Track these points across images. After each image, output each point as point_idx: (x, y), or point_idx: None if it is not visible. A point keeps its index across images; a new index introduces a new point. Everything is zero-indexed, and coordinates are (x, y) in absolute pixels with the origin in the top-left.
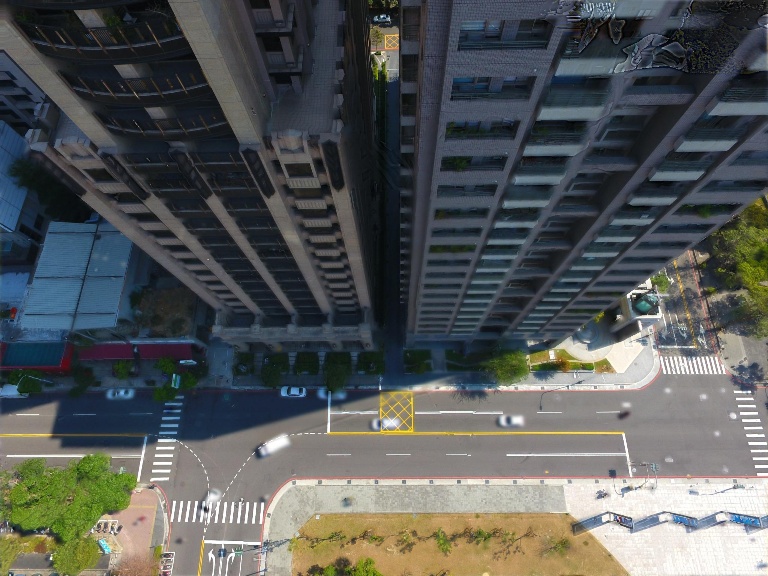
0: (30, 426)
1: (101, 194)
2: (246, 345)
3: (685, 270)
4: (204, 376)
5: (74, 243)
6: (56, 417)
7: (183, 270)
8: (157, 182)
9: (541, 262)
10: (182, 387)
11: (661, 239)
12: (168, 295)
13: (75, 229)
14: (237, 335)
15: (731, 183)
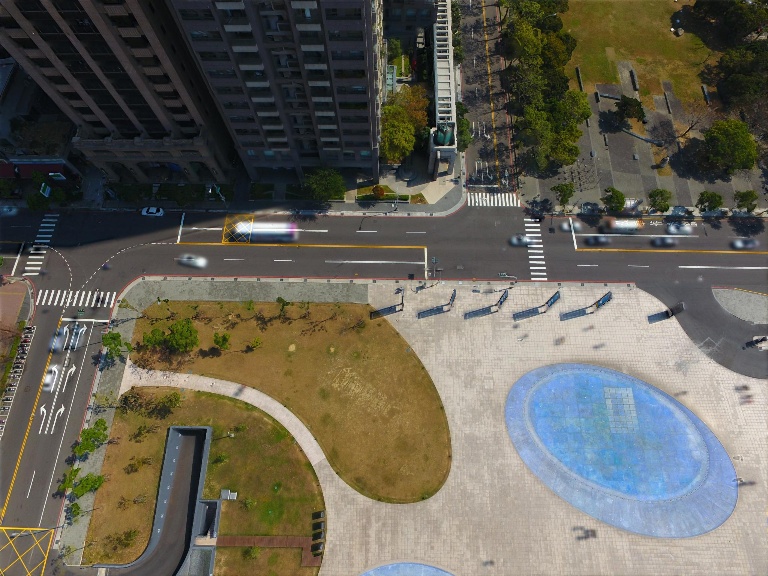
0: None
1: None
2: (115, 175)
3: (501, 129)
4: (78, 200)
5: None
6: None
7: (26, 58)
8: None
9: None
10: (53, 199)
11: None
12: (47, 127)
13: None
14: (94, 146)
15: None
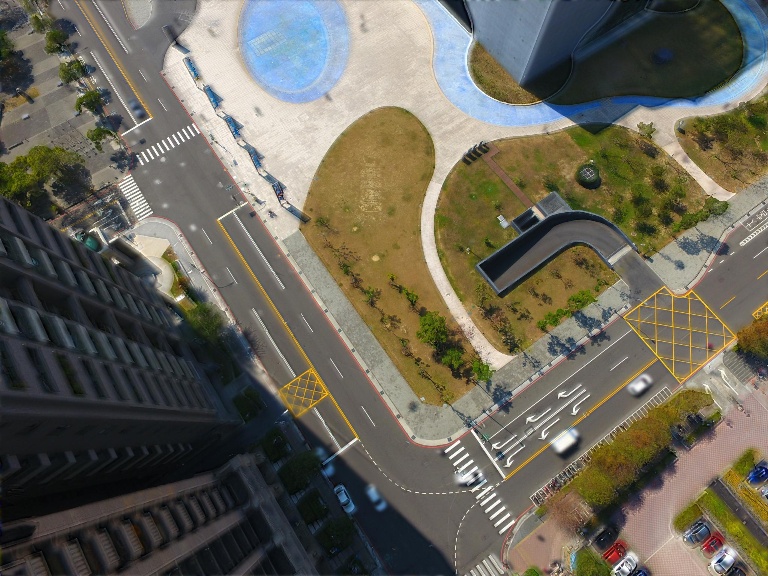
0: None
1: None
2: None
3: None
4: None
5: None
6: None
7: None
8: None
9: (65, 312)
10: None
11: None
12: None
13: None
14: None
15: None
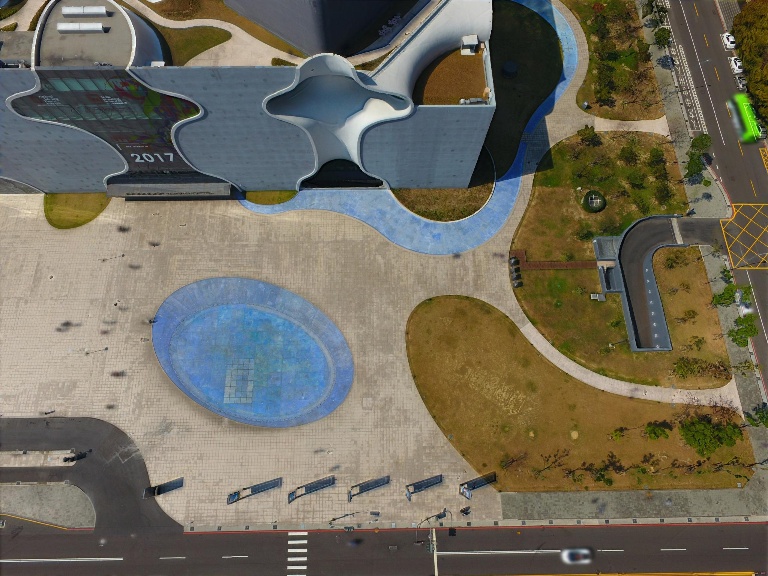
0: None
1: None
2: None
3: None
4: None
5: None
6: None
7: None
8: None
9: None
10: None
11: None
12: None
13: None
14: None
15: None
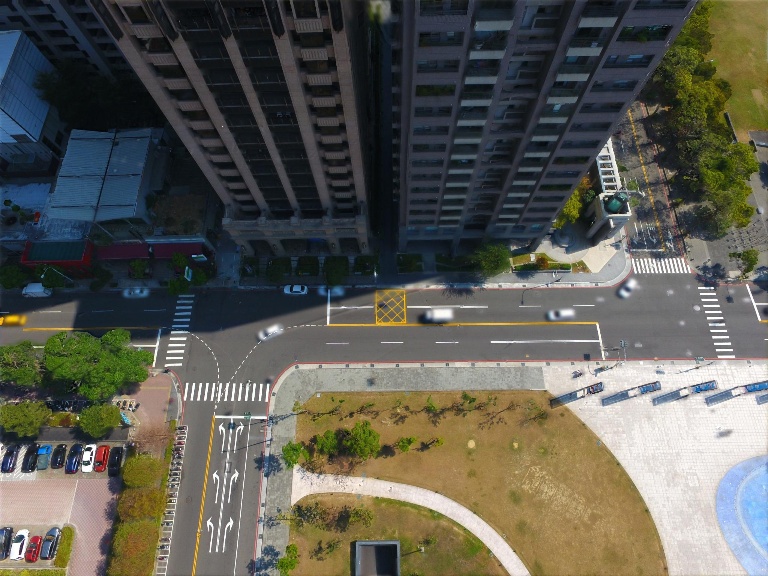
0: (52, 321)
1: (135, 41)
2: (252, 249)
3: (656, 185)
4: (213, 278)
5: (94, 148)
6: (76, 314)
7: (199, 147)
8: (185, 19)
9: (515, 128)
10: (194, 282)
11: (612, 76)
12: (180, 201)
13: (95, 136)
14: (245, 228)
15: (660, 1)
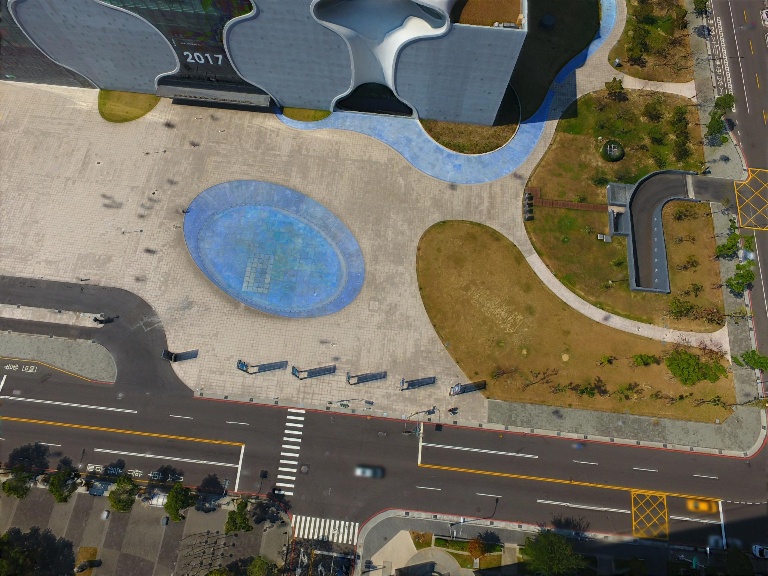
0: None
1: None
2: None
3: None
4: None
5: None
6: None
7: None
8: None
9: None
10: None
11: None
12: None
13: None
14: None
15: None
